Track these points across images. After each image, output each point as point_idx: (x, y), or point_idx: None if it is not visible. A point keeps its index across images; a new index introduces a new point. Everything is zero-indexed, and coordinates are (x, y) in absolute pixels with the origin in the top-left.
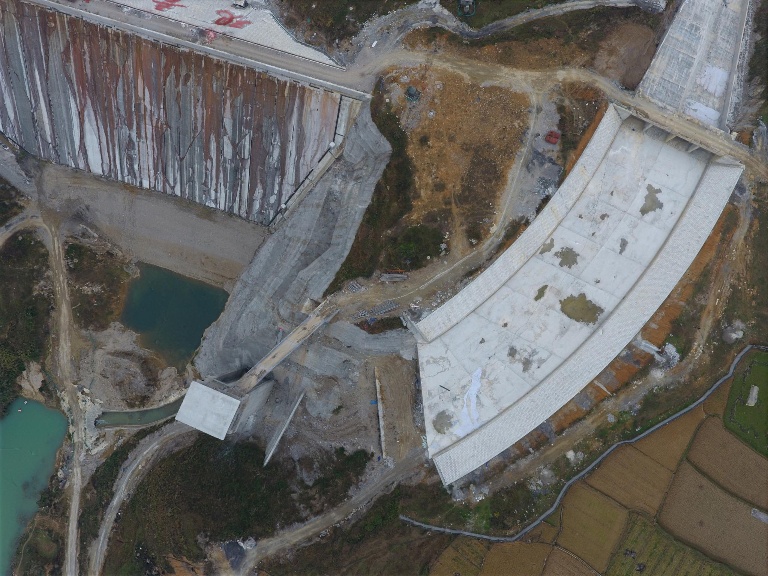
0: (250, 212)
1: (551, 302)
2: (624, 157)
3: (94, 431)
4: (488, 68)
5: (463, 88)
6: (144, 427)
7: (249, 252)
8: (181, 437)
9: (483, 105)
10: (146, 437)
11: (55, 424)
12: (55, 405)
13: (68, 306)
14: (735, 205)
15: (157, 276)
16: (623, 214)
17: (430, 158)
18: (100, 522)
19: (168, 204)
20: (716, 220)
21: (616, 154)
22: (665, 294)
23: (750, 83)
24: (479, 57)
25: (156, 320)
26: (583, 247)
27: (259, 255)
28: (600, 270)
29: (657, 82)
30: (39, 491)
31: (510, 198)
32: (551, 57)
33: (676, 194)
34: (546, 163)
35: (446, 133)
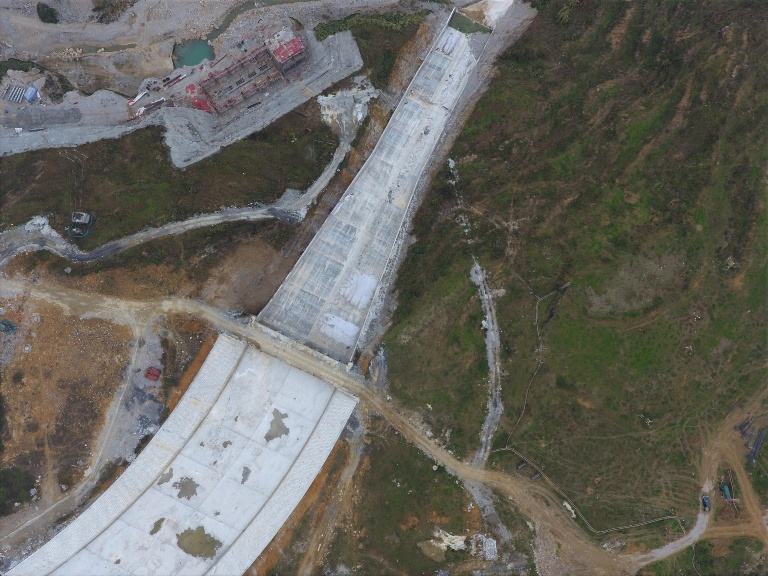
0: None
1: (167, 536)
2: (250, 380)
3: None
4: (90, 298)
5: (62, 320)
6: None
7: None
8: None
9: (82, 339)
10: None
11: None
12: None
13: None
14: (346, 441)
15: None
16: (247, 441)
17: (24, 396)
18: None
19: None
20: (326, 457)
21: (242, 377)
22: (269, 537)
23: (392, 296)
24: (80, 287)
25: None
26: (203, 477)
27: None
28: (220, 501)
29: (295, 295)
30: None
31: (107, 438)
32: (157, 286)
33: (303, 419)
34: (147, 400)
35: (42, 369)
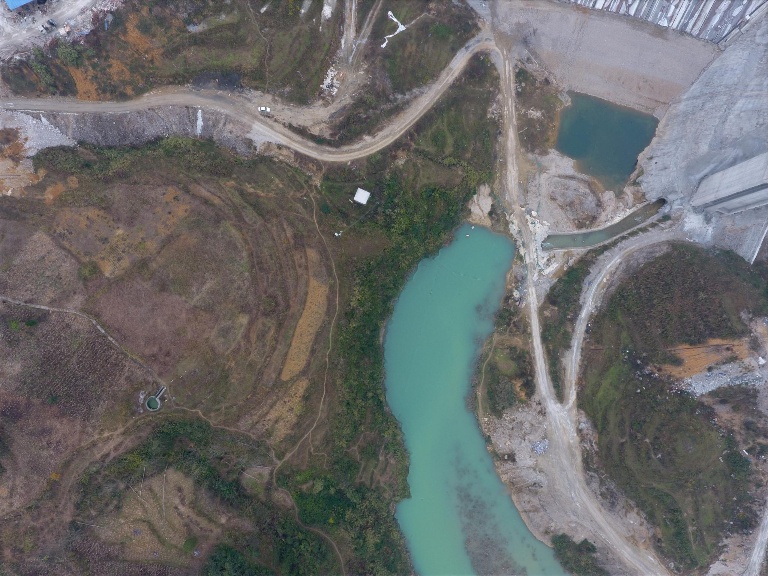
0: (704, 29)
1: None
2: None
3: (543, 253)
4: None
5: None
6: (592, 247)
7: (695, 71)
8: (648, 248)
9: None
10: (605, 253)
11: (500, 249)
12: (503, 229)
13: (515, 130)
14: None
15: (585, 105)
16: None
17: None
18: (572, 333)
19: (621, 24)
20: None
21: None
22: None
23: None
24: None
25: (587, 148)
26: None
27: (725, 66)
28: None
29: None
30: (493, 313)
31: None
32: None
33: None
34: None
35: None
